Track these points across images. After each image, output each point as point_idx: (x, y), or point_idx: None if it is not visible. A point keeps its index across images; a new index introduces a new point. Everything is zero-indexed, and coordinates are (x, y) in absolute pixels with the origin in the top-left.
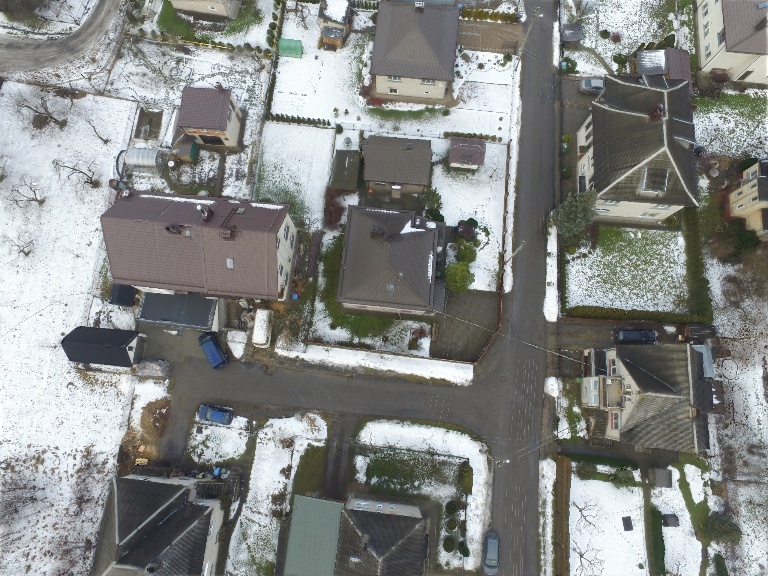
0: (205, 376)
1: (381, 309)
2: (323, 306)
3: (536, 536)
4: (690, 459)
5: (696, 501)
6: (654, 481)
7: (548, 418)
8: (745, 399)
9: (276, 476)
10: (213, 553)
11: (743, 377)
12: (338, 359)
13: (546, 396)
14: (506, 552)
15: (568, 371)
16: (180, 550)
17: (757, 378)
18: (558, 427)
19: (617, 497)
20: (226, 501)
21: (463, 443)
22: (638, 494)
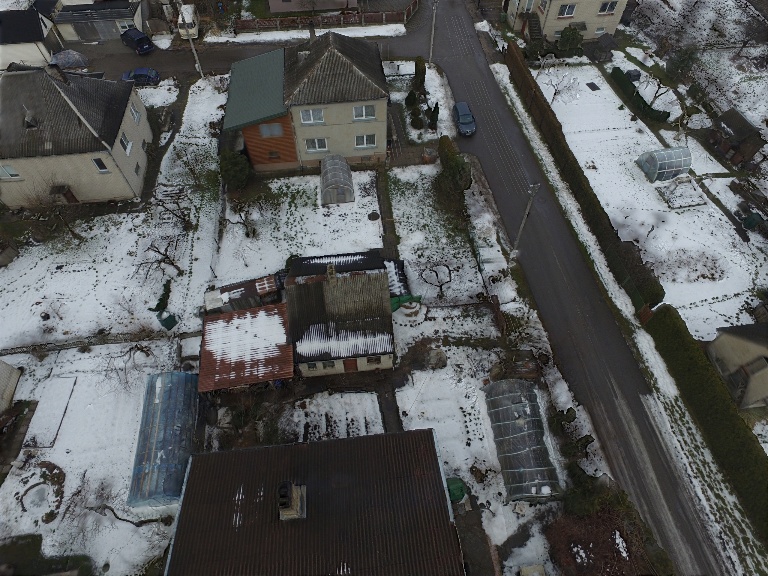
0: (128, 62)
1: (306, 4)
2: (249, 14)
3: (506, 107)
4: (628, 45)
5: (648, 65)
6: (602, 53)
7: (486, 43)
8: (655, 13)
9: (213, 111)
10: (139, 152)
11: (645, 3)
12: (270, 37)
13: (479, 32)
14: (480, 121)
15: (493, 19)
16: (93, 89)
17: (657, 0)
18: (498, 45)
19: (574, 74)
20: (154, 114)
21: (409, 65)
22: (593, 69)
